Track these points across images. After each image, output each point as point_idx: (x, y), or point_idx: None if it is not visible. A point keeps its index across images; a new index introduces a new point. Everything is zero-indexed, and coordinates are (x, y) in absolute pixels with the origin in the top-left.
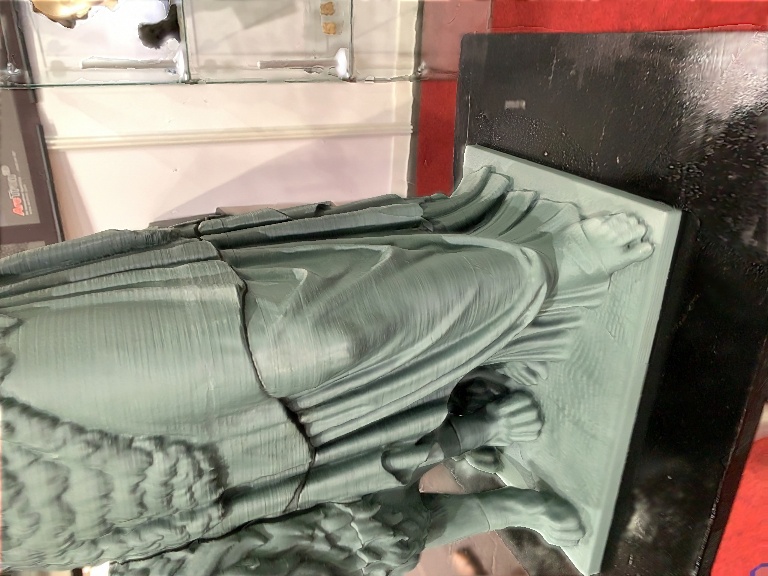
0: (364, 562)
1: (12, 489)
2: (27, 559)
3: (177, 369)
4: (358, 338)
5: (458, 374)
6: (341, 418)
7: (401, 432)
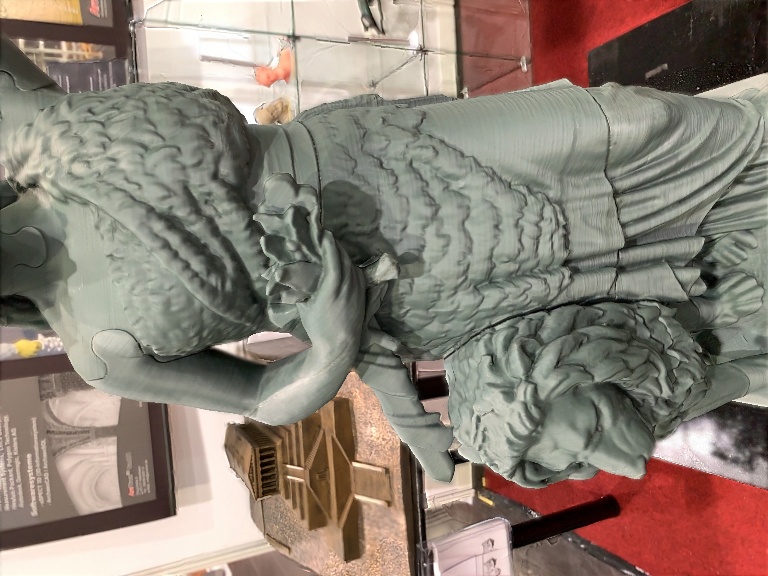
0: (677, 359)
1: (433, 207)
2: (431, 291)
3: (552, 110)
4: (667, 104)
5: (714, 189)
6: (640, 209)
7: (675, 247)
